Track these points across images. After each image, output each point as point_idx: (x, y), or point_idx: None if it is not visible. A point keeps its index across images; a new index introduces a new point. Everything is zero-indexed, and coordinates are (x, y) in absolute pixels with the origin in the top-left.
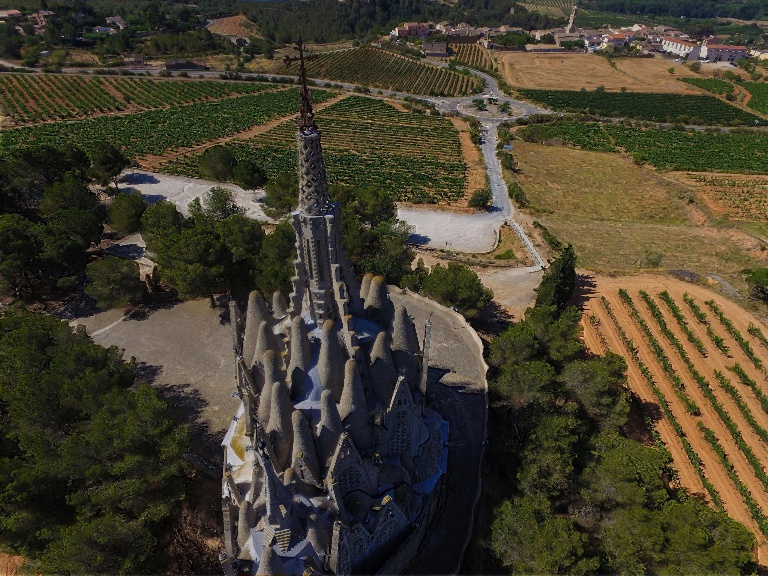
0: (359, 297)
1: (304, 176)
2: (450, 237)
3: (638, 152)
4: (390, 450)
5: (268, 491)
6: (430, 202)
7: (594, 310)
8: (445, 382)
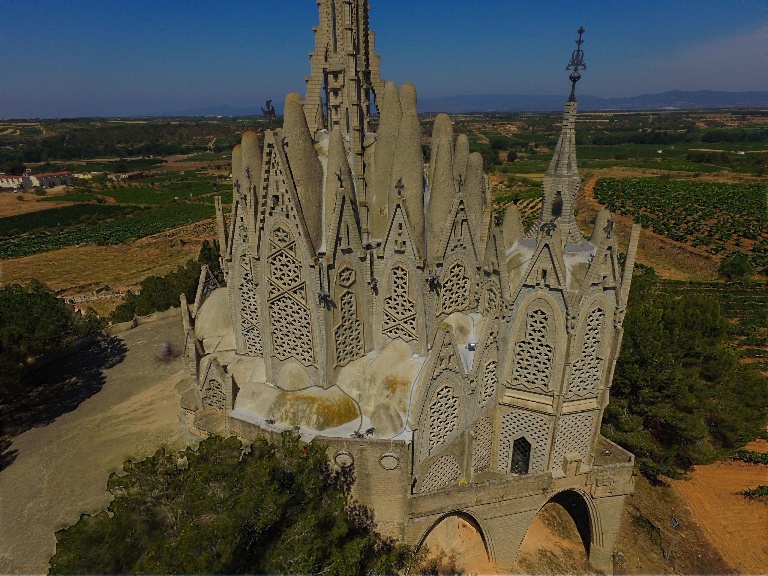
0: None
1: None
2: None
3: None
4: None
5: None
6: None
7: None
8: None
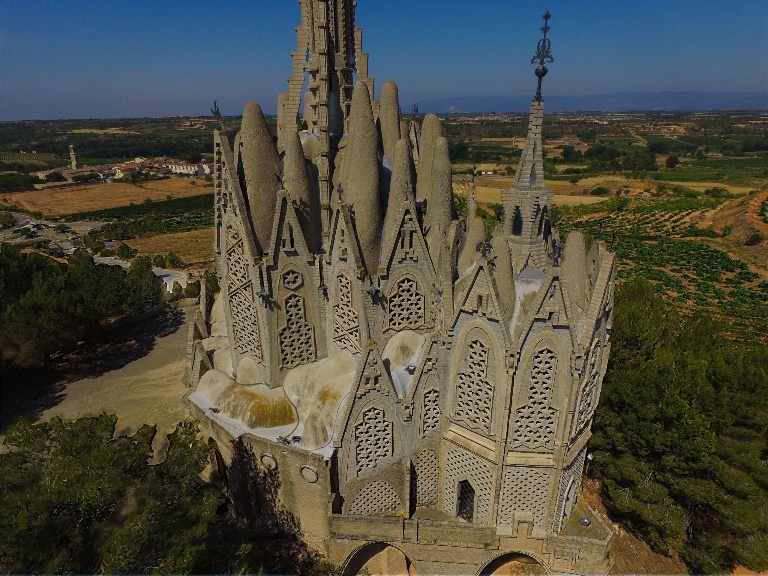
0: None
1: None
2: None
3: None
4: None
5: (540, 163)
6: None
7: None
8: None
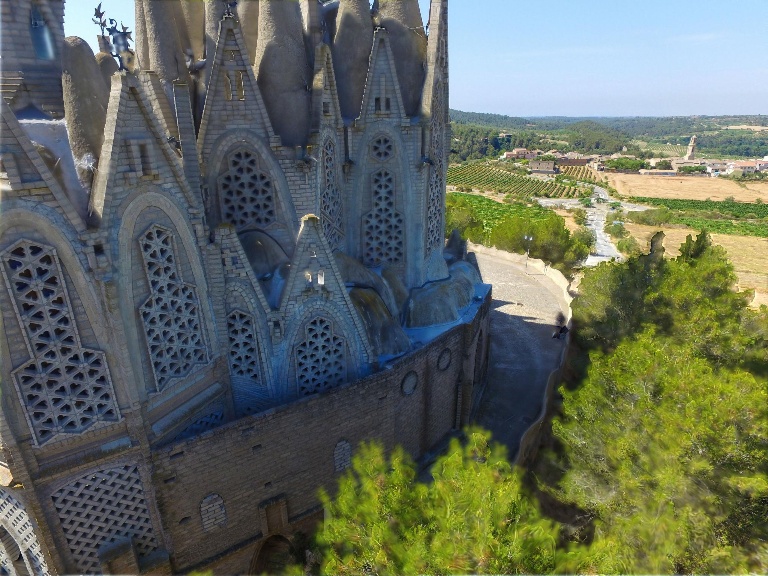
0: None
1: None
2: None
3: None
4: (365, 247)
5: None
6: None
7: None
8: (504, 310)
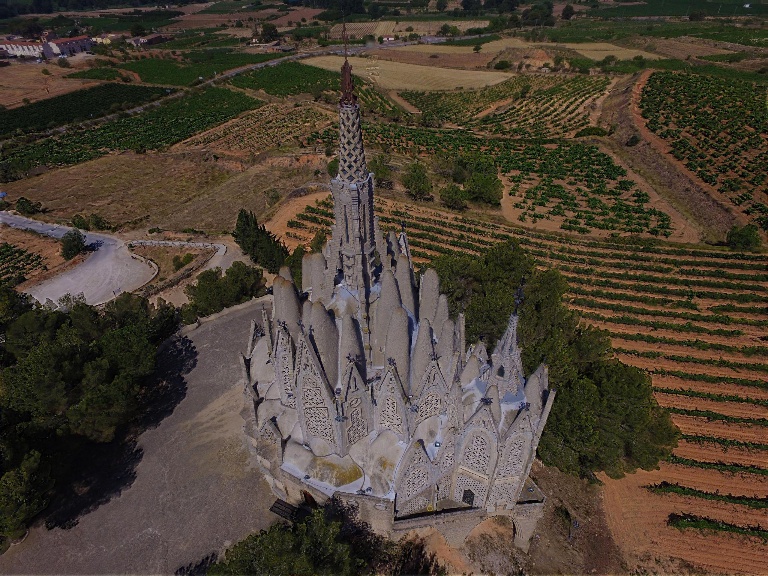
0: None
1: (358, 146)
2: (101, 289)
3: (123, 145)
4: None
5: None
6: (20, 281)
7: (291, 244)
8: None
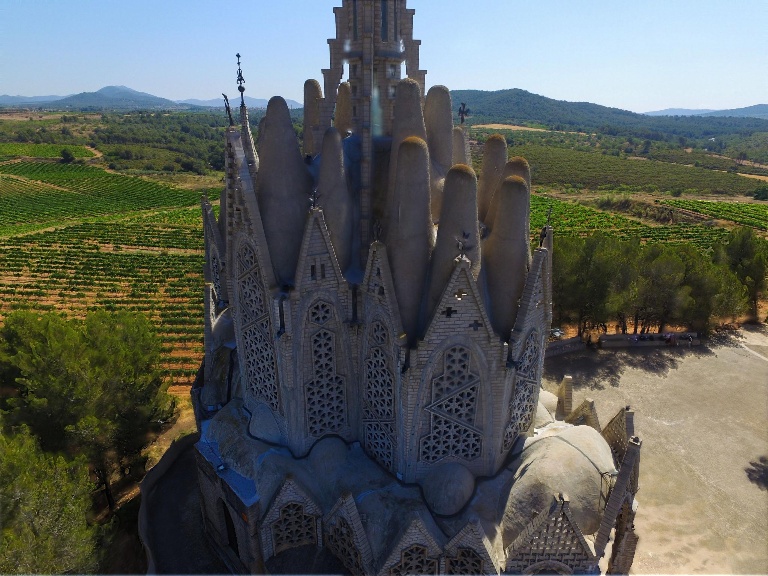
0: (363, 116)
1: None
2: None
3: None
4: None
5: None
6: None
7: None
8: None
